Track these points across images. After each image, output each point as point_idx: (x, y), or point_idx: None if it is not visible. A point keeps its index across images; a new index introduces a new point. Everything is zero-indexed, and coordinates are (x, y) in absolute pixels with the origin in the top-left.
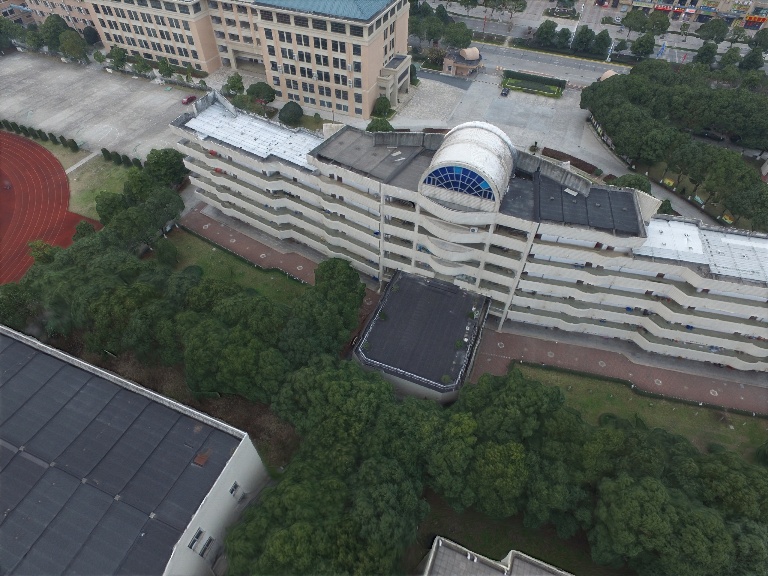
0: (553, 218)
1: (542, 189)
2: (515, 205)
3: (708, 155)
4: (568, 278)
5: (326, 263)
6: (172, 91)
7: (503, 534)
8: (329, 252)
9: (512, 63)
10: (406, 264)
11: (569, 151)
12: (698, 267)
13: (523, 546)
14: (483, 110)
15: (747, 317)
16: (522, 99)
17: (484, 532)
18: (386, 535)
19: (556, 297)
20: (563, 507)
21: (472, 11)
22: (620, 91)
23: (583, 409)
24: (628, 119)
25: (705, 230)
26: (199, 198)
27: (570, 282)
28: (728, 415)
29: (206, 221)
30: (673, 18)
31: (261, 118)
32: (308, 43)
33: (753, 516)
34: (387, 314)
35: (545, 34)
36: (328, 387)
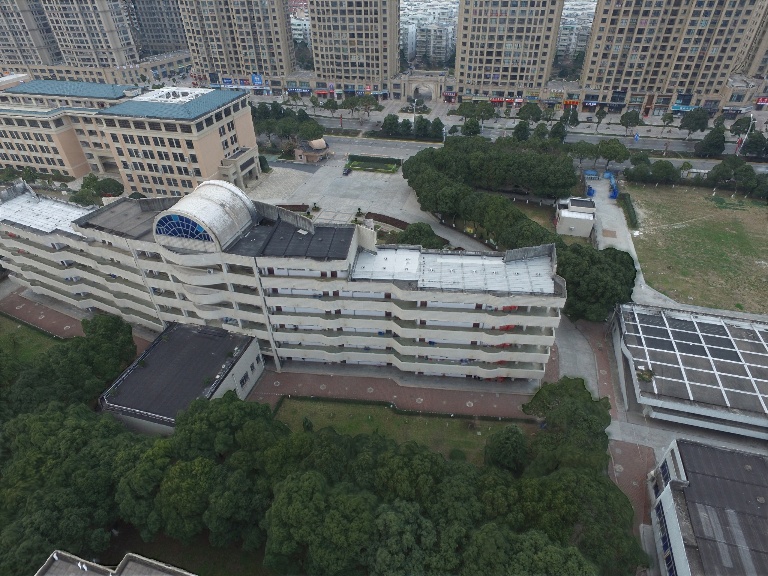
0: (275, 253)
1: (277, 232)
2: (246, 246)
3: (482, 202)
4: (317, 309)
5: (91, 320)
6: None
7: (221, 566)
8: (122, 315)
9: (361, 150)
10: (180, 315)
11: (391, 214)
12: (408, 283)
13: (238, 575)
14: (323, 188)
15: (470, 326)
16: (361, 176)
17: (201, 567)
18: (20, 562)
19: (317, 330)
20: (239, 516)
21: (338, 113)
22: (425, 160)
23: (340, 433)
24: (427, 181)
25: (425, 254)
26: (13, 281)
27: (319, 313)
28: (478, 423)
29: (21, 302)
30: (507, 107)
31: (61, 201)
32: (149, 142)
33: (407, 496)
34: (147, 362)
35: (389, 125)
36: (33, 428)
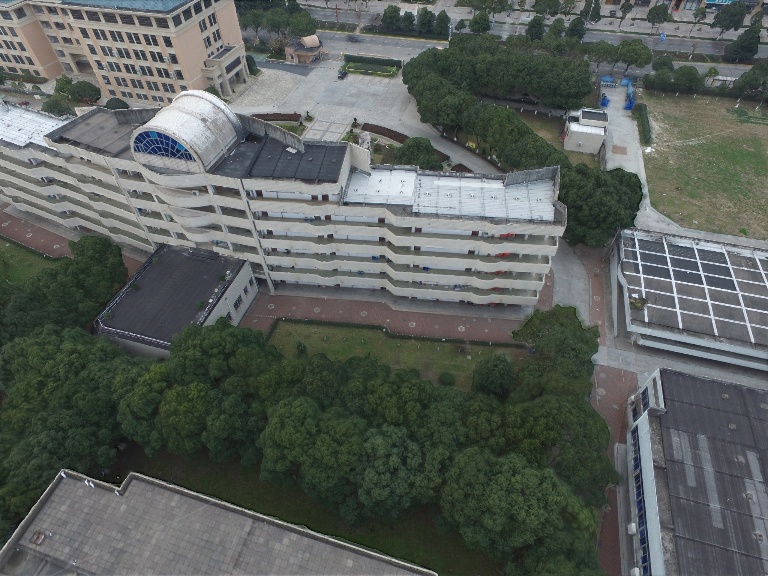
0: (263, 174)
1: (265, 150)
2: (231, 166)
3: (486, 114)
4: (309, 233)
5: (78, 241)
6: (6, 98)
7: (222, 476)
8: (110, 235)
9: (358, 48)
10: (169, 237)
11: (389, 125)
12: (403, 208)
13: (239, 484)
14: (317, 93)
15: (466, 252)
16: (358, 81)
17: (204, 476)
18: (32, 477)
19: (309, 254)
20: (235, 436)
21: (333, 3)
22: (428, 63)
23: (333, 356)
24: (429, 88)
25: (422, 175)
26: None
27: (312, 237)
28: (468, 347)
29: (7, 219)
30: None
31: (32, 110)
32: (123, 39)
33: (395, 421)
34: (139, 285)
35: (389, 19)
36: (30, 352)
